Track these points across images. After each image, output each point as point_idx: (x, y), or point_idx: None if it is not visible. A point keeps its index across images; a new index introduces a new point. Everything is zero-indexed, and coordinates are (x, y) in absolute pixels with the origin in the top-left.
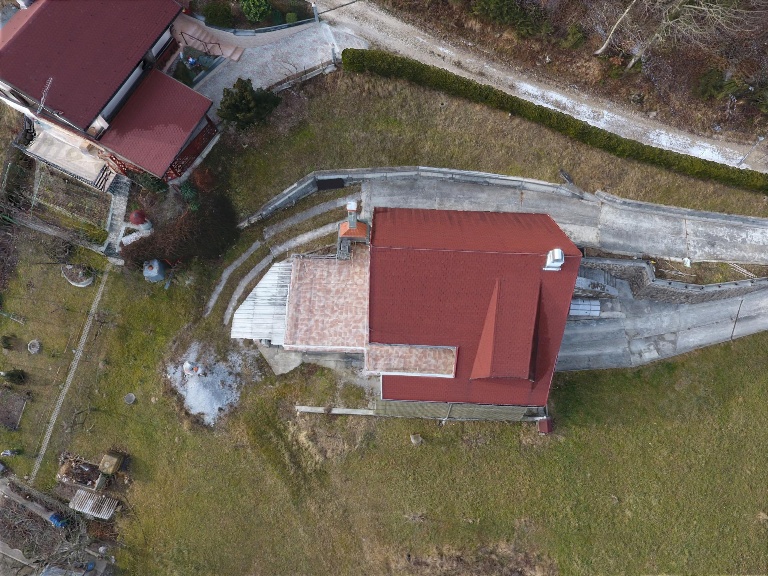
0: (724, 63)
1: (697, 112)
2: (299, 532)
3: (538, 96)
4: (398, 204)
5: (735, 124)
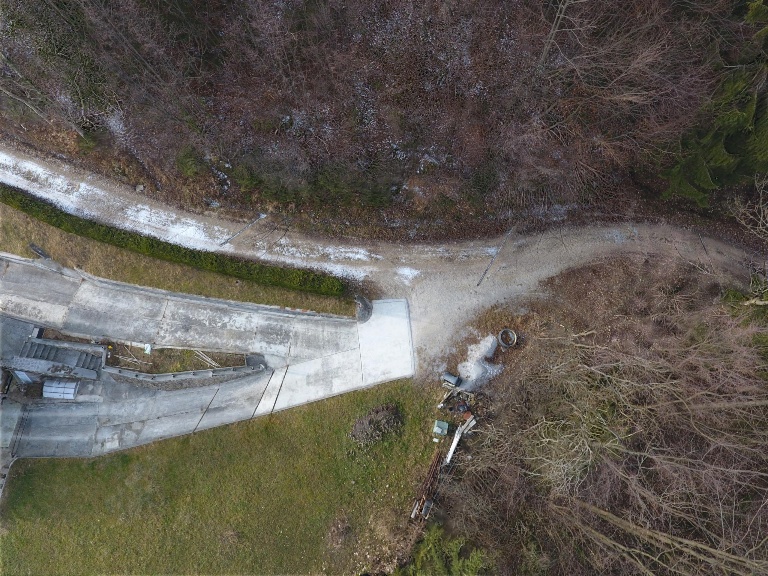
0: (200, 138)
1: (186, 187)
2: None
3: (9, 166)
4: None
5: (232, 200)
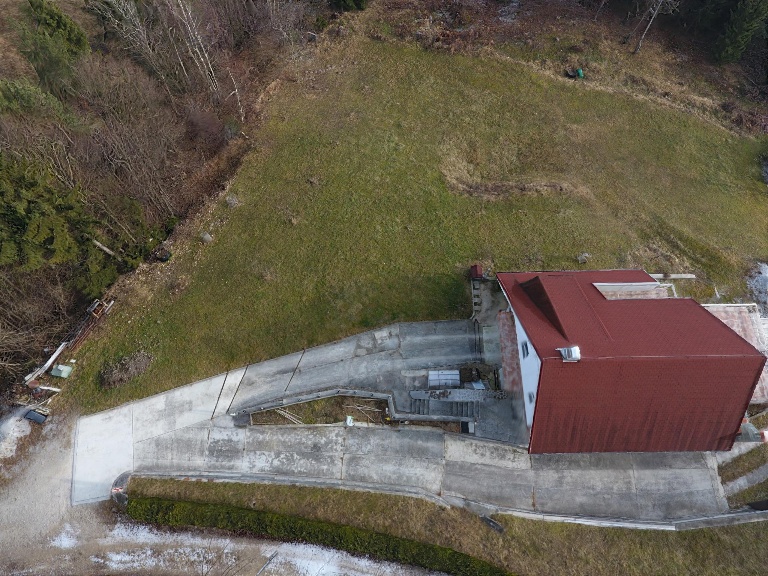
0: None
1: None
2: (647, 201)
3: None
4: (679, 481)
5: None
